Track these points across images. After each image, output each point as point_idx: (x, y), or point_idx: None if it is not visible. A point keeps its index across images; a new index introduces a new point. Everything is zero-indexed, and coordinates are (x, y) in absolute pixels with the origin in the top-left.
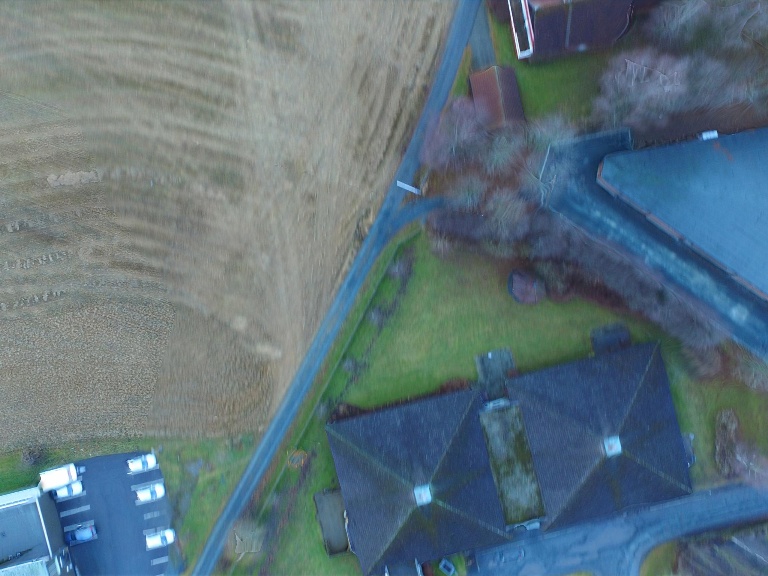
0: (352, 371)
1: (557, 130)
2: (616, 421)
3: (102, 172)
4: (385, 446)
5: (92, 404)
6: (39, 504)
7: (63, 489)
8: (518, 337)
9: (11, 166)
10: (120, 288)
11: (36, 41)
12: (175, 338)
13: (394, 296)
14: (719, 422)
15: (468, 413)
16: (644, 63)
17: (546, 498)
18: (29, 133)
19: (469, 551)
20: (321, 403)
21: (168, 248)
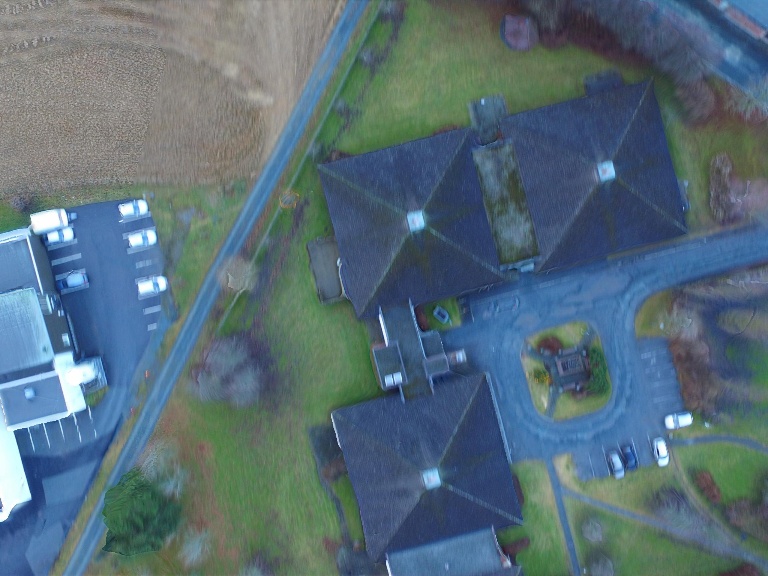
0: (344, 118)
1: None
2: (610, 149)
3: None
4: (378, 180)
5: (83, 151)
6: (30, 241)
7: (54, 233)
8: (511, 83)
9: None
10: (110, 34)
11: None
12: (166, 85)
13: (386, 42)
14: (713, 167)
15: (461, 149)
16: None
17: (540, 236)
18: None
19: (463, 299)
20: (313, 149)
21: None
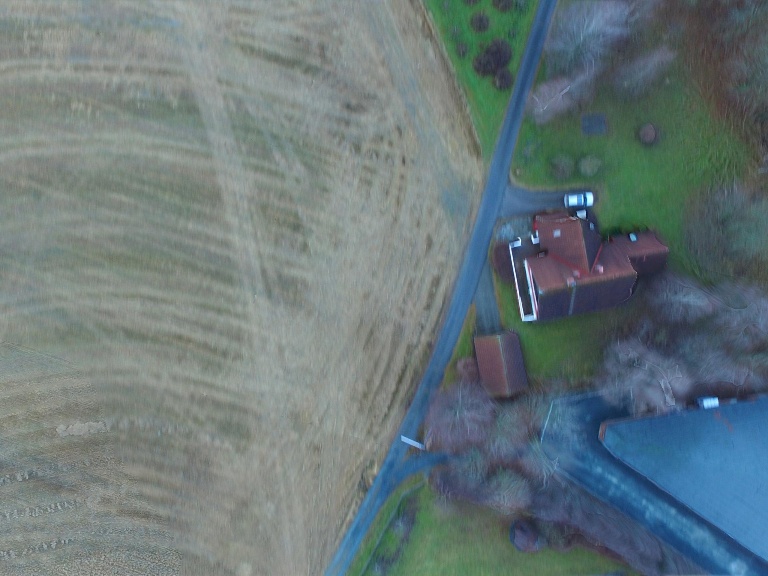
0: None
1: (560, 389)
2: None
3: (110, 422)
4: None
5: None
6: None
7: None
8: None
9: (21, 417)
10: (127, 536)
11: (46, 296)
12: None
13: (397, 545)
14: None
15: None
16: (646, 328)
17: None
18: (39, 384)
19: None
20: None
21: (175, 497)
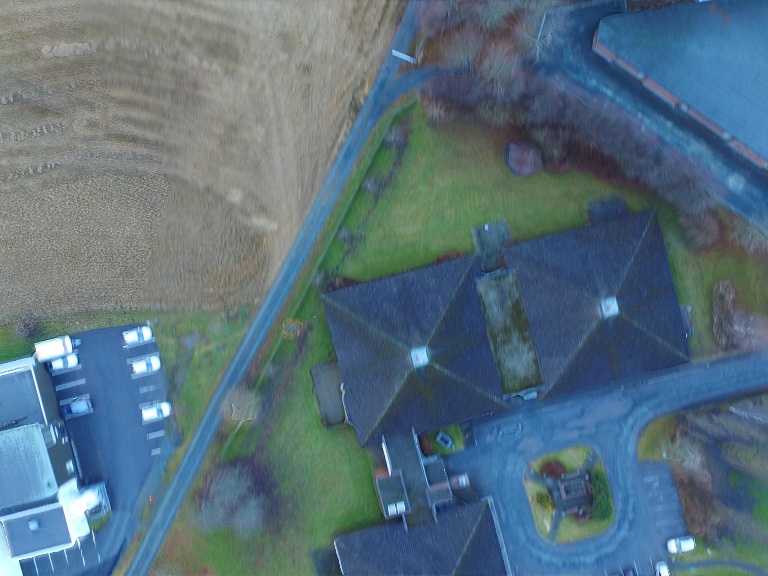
0: (348, 243)
1: None
2: (613, 284)
3: (96, 43)
4: (381, 312)
5: (87, 277)
6: (34, 372)
7: (58, 360)
8: (514, 209)
9: (5, 37)
10: (115, 160)
11: None
12: (170, 211)
13: (390, 168)
14: (716, 293)
15: (465, 280)
16: None
17: (543, 366)
18: (23, 4)
19: (466, 424)
20: (317, 275)
21: (163, 120)
